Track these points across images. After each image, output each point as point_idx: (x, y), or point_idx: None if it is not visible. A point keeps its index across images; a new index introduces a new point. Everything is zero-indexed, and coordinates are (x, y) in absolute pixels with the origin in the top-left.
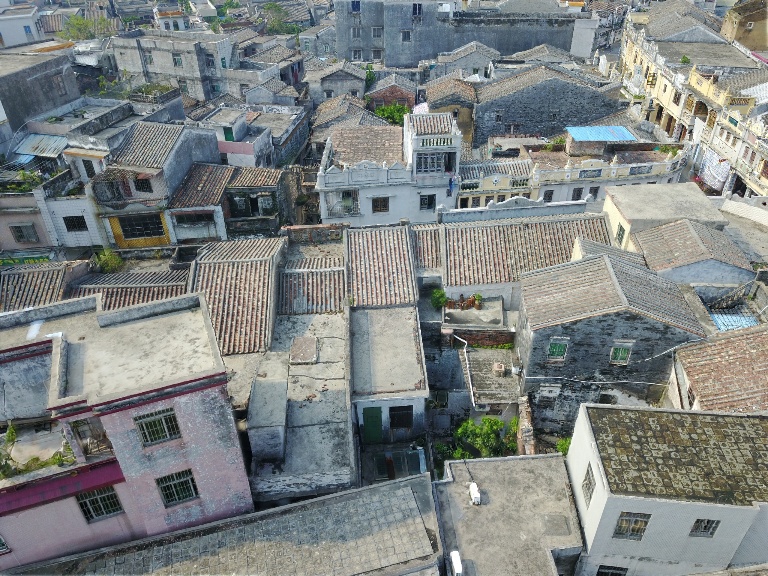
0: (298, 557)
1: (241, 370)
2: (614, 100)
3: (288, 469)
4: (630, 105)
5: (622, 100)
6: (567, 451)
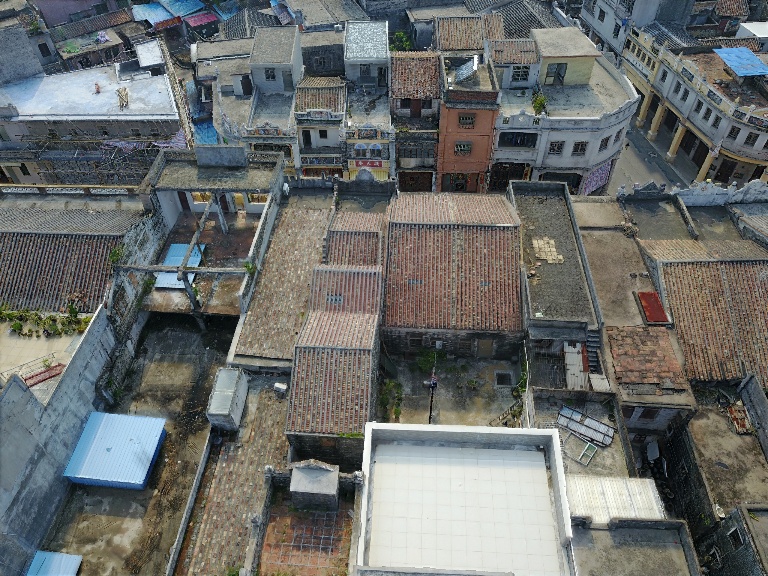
0: (337, 3)
1: None
2: None
3: None
4: None
5: None
6: None
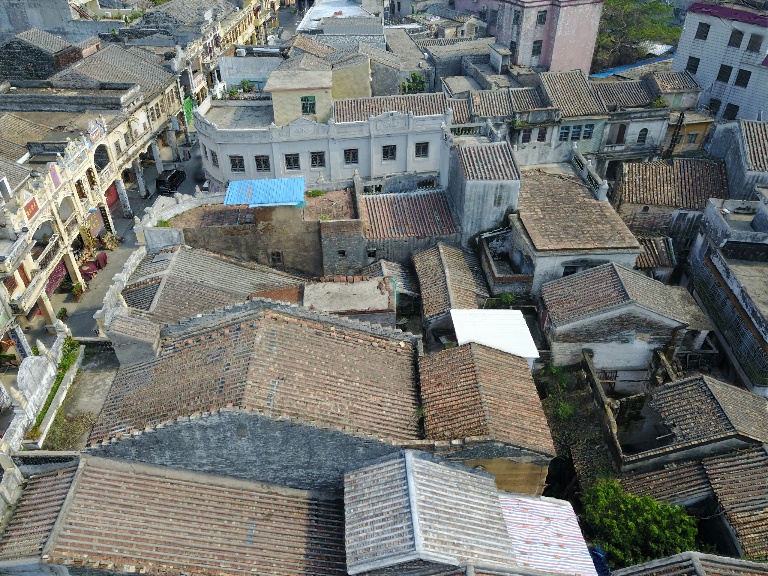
0: None
1: (524, 72)
2: None
3: (486, 65)
4: None
5: None
6: None
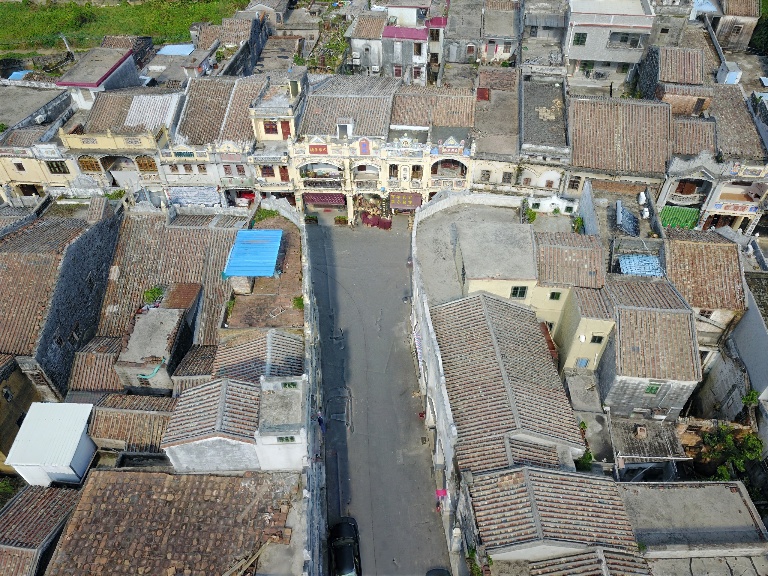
0: None
1: None
2: (111, 216)
3: None
4: (127, 208)
5: (116, 210)
6: (758, 397)
